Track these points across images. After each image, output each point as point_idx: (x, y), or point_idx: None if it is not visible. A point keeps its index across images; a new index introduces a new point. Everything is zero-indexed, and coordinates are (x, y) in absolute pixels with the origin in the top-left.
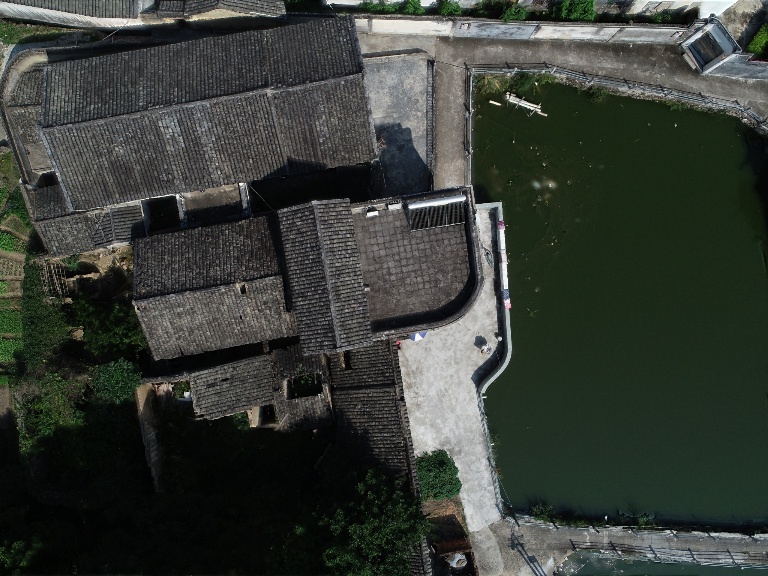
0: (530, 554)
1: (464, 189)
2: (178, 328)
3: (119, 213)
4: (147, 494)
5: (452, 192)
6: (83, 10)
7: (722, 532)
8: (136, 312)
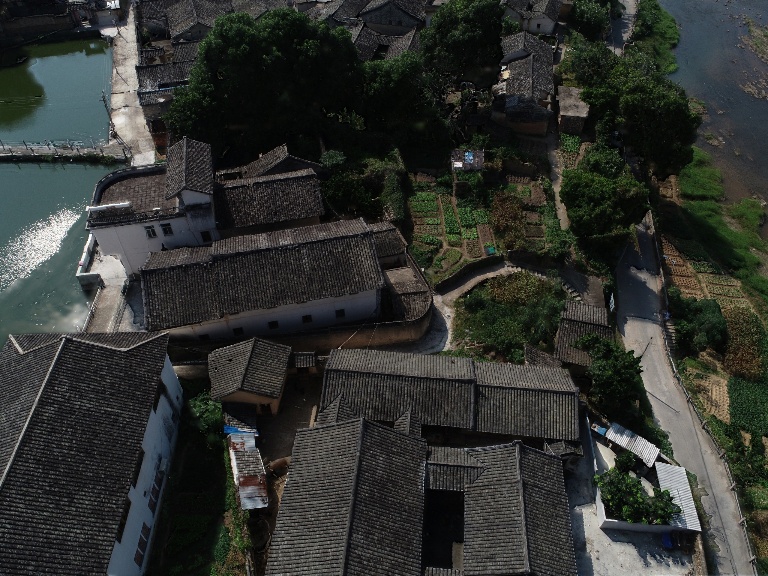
0: (122, 145)
1: (90, 218)
2: None
3: None
4: (325, 136)
5: (99, 218)
6: (376, 352)
7: (4, 156)
8: None
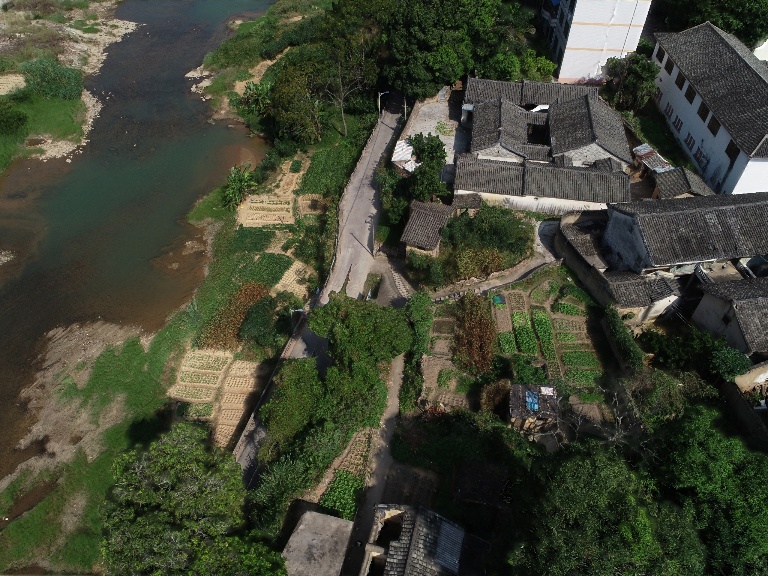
0: None
1: None
2: (765, 326)
3: (668, 280)
4: None
5: None
6: (596, 199)
7: None
8: (736, 310)
